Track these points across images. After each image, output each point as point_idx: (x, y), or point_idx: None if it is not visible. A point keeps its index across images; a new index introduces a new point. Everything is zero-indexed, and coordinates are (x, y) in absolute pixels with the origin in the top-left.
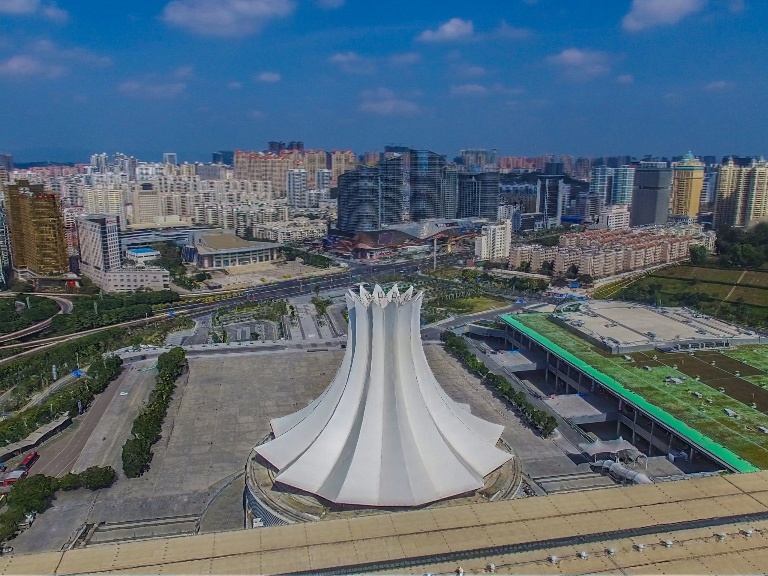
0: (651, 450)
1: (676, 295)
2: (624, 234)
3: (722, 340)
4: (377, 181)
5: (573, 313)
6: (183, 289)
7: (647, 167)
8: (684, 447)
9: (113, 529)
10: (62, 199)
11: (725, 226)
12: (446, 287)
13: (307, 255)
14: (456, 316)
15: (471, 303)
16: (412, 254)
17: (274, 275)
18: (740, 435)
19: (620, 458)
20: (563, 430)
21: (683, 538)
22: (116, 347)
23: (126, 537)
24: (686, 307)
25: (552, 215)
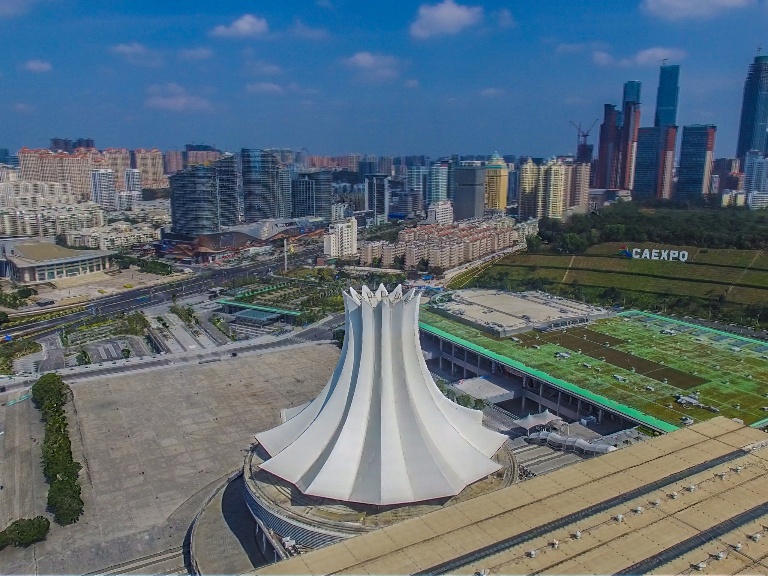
0: None
1: (522, 281)
2: (454, 228)
3: (583, 317)
4: (215, 181)
5: (450, 303)
6: (5, 308)
7: (465, 166)
8: (588, 412)
9: None
10: None
11: (546, 218)
12: (312, 287)
13: (144, 262)
14: (333, 314)
15: (342, 301)
16: (256, 256)
17: (112, 286)
18: (636, 395)
19: (544, 429)
20: (485, 411)
21: (696, 482)
22: None
23: None
24: (540, 291)
25: (380, 212)
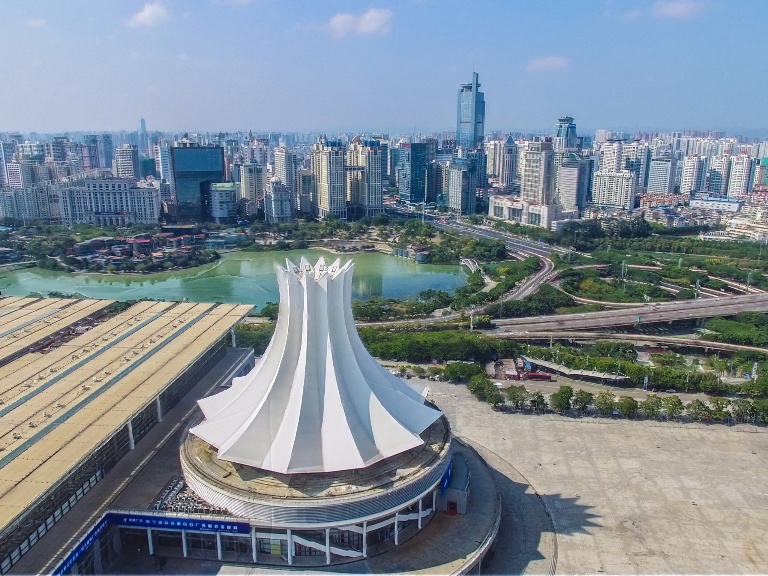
0: None
1: None
2: None
3: None
4: None
5: None
6: None
7: None
8: None
9: None
10: None
11: None
12: None
13: None
14: None
15: None
16: None
17: None
18: None
19: None
20: None
21: None
22: None
23: None
24: None
25: None
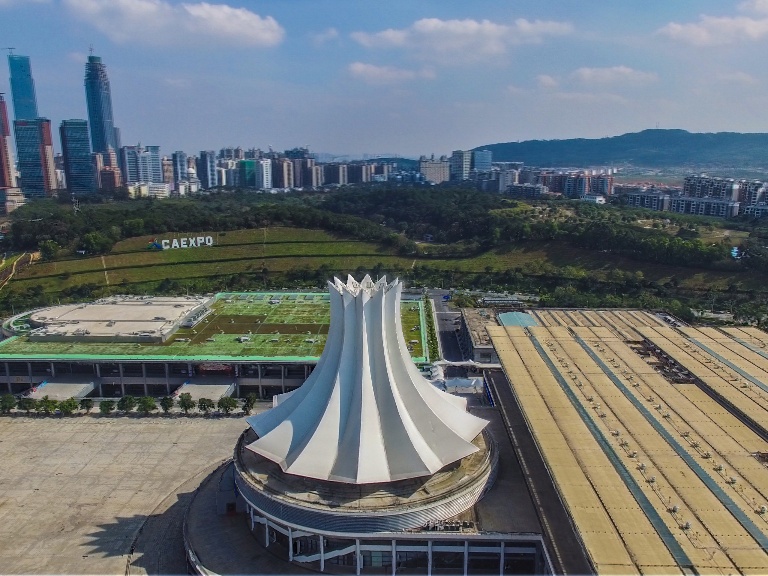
0: (285, 391)
1: (65, 291)
2: None
3: (202, 306)
4: None
5: (50, 327)
6: None
7: None
8: None
9: None
10: None
11: (23, 221)
12: None
13: None
14: None
15: None
16: None
17: None
18: None
19: None
20: None
21: None
22: None
23: None
24: (117, 295)
25: None
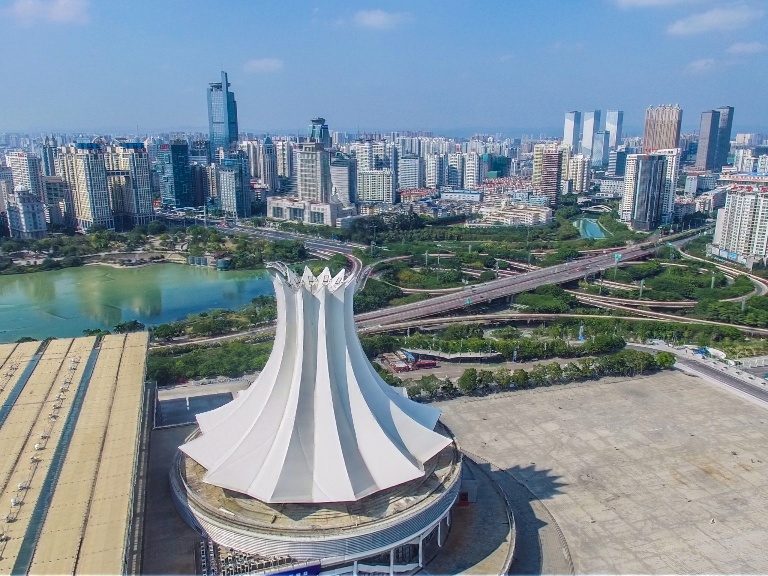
0: None
1: None
2: None
3: None
4: None
5: None
6: None
7: None
8: None
9: None
10: None
11: None
12: None
13: None
14: None
15: None
16: None
17: None
18: None
19: None
20: None
21: None
22: (696, 342)
23: None
24: None
25: None
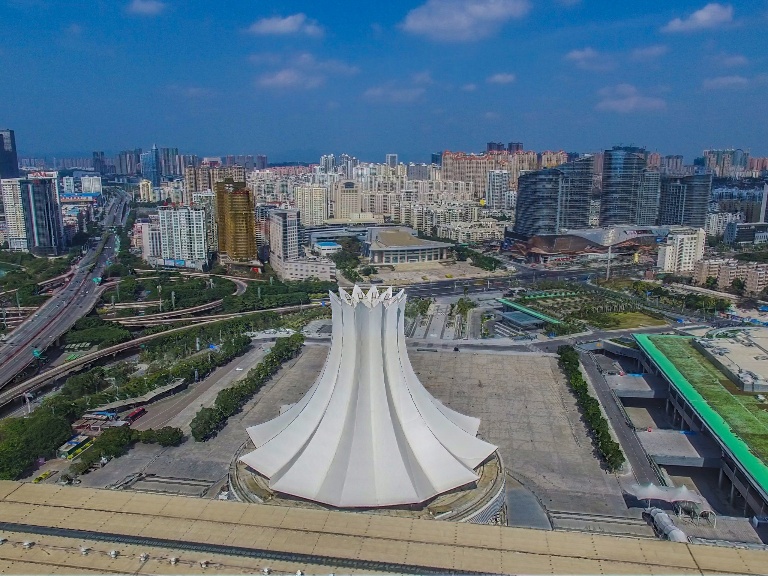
0: (746, 509)
1: None
2: None
3: None
4: (557, 183)
5: (723, 339)
6: (349, 281)
7: None
8: None
9: (154, 481)
10: (255, 195)
11: None
12: (601, 299)
13: (476, 256)
14: (596, 330)
15: (621, 318)
16: (591, 262)
17: (437, 274)
18: None
19: (688, 510)
20: (638, 468)
21: None
22: (263, 328)
23: (158, 490)
24: None
25: None
